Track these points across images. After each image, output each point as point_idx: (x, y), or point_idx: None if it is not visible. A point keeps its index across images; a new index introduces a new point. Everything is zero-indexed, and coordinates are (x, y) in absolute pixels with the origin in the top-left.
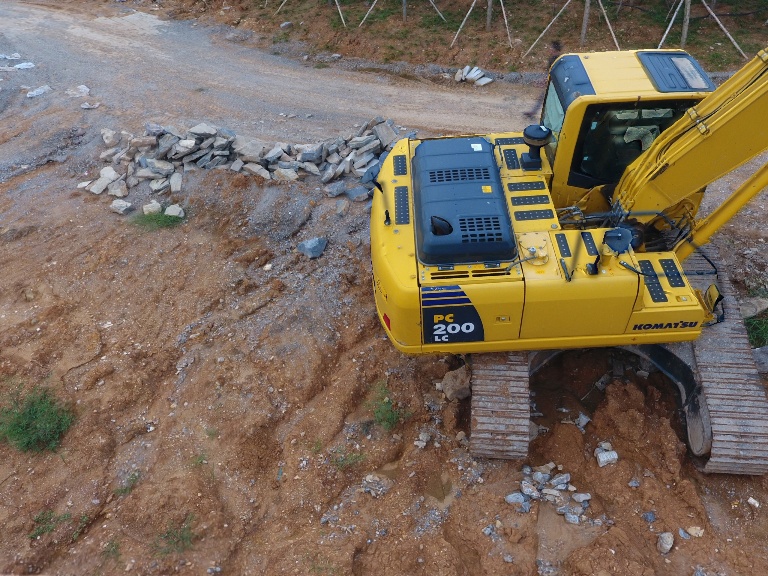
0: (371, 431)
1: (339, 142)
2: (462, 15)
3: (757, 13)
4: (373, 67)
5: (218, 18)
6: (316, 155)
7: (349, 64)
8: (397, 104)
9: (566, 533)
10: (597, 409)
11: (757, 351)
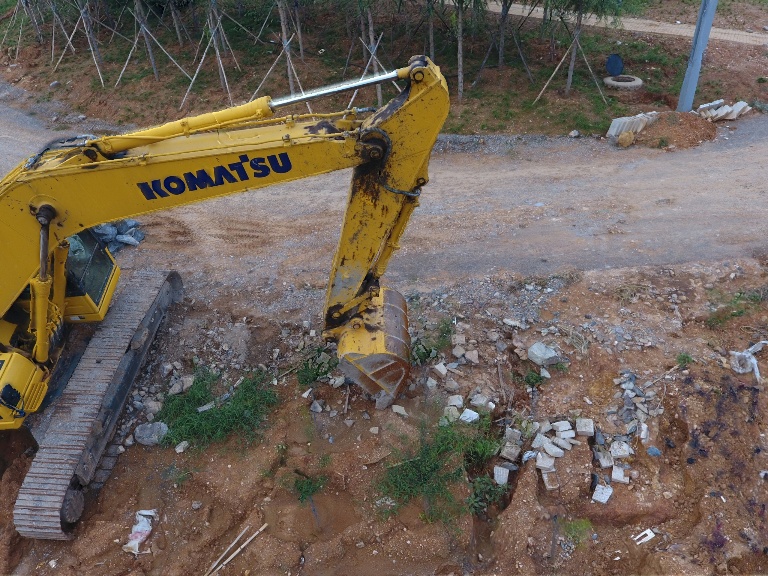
0: None
1: None
2: (212, 75)
3: (467, 75)
4: (106, 129)
5: (5, 75)
6: None
7: (87, 126)
8: None
9: None
10: None
11: (148, 427)
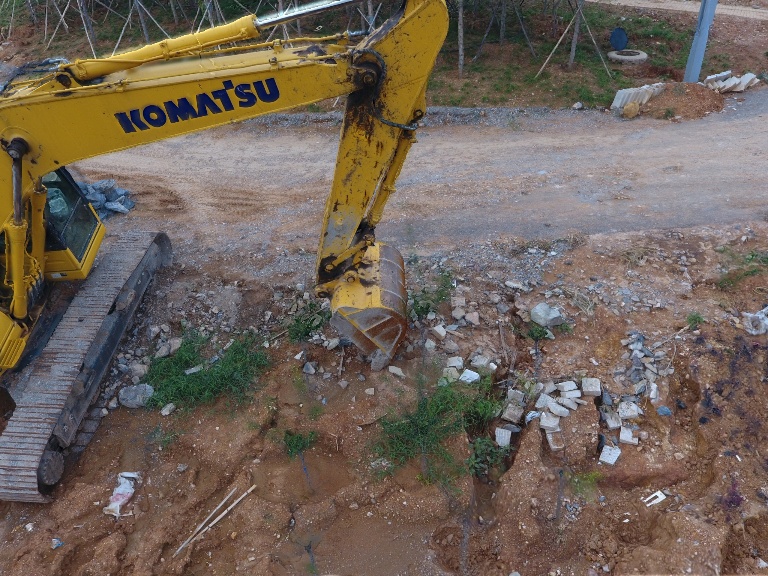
0: None
1: None
2: None
3: (468, 49)
4: None
5: None
6: None
7: None
8: None
9: None
10: None
11: (133, 389)
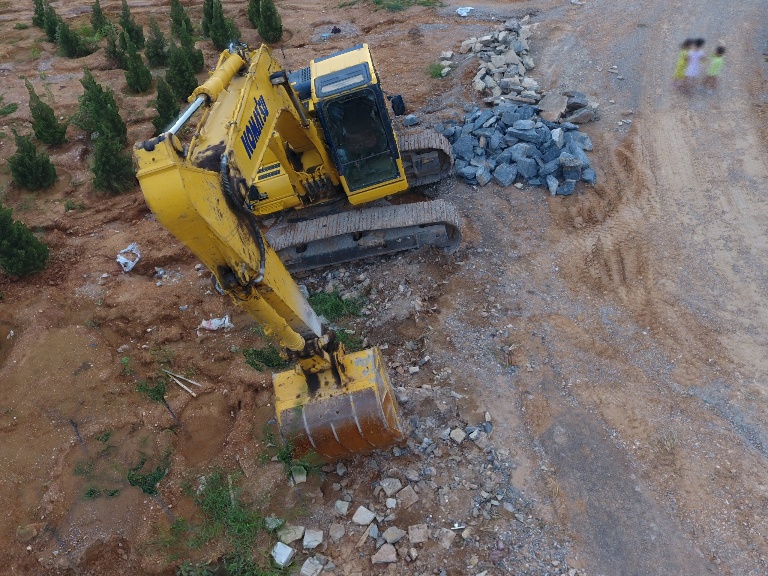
0: None
1: (531, 89)
2: None
3: None
4: None
5: None
6: (503, 85)
7: None
8: (693, 114)
9: None
10: None
11: None
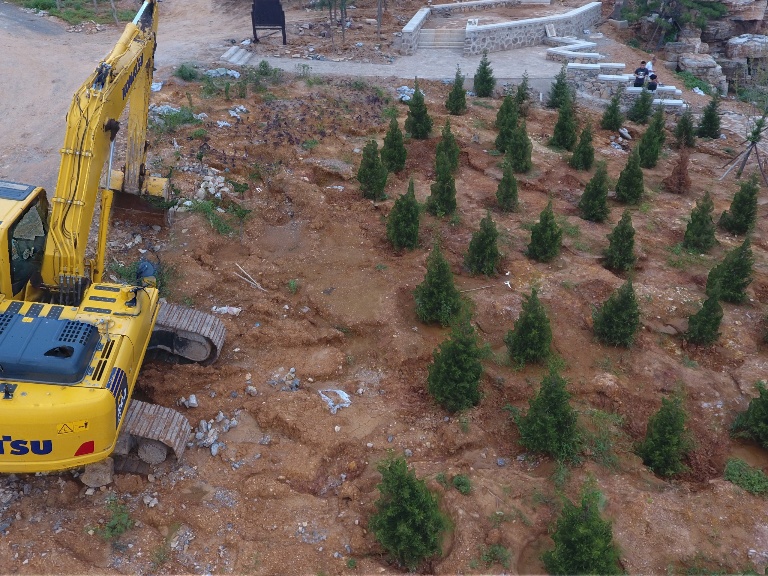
0: (125, 544)
1: None
2: None
3: None
4: None
5: None
6: None
7: None
8: None
9: (243, 428)
10: (152, 398)
11: None
